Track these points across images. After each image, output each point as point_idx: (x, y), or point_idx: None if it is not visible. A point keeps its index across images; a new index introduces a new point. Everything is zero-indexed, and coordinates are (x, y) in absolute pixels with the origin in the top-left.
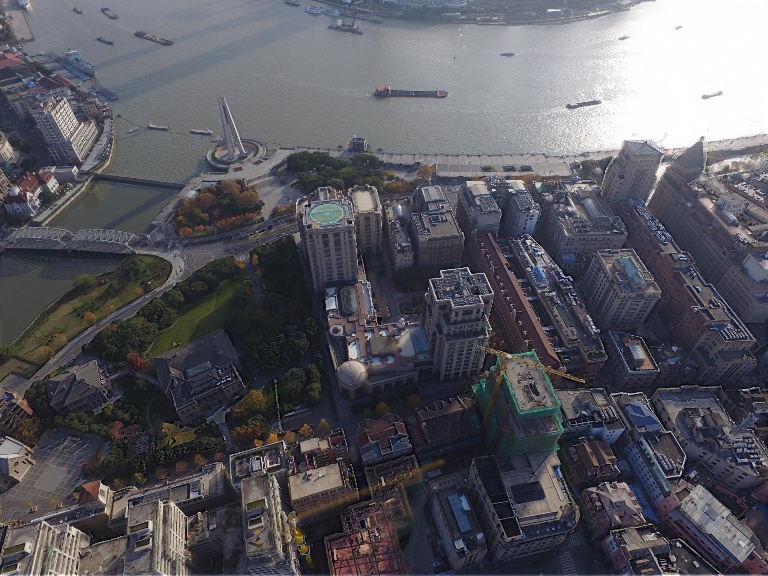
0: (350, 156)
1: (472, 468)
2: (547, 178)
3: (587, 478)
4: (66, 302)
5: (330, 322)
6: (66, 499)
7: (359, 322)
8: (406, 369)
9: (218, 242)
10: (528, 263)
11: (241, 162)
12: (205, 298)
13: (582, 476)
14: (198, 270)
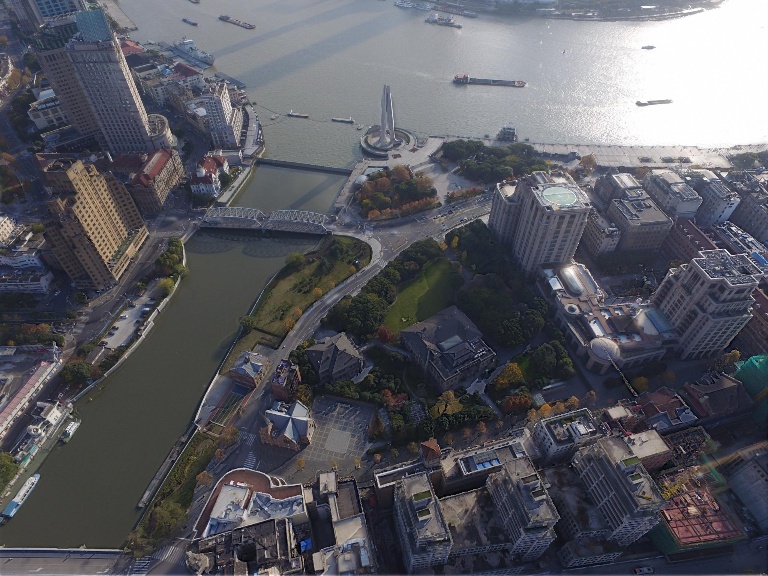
0: (506, 145)
1: None
2: (708, 169)
3: None
4: (282, 278)
5: (562, 301)
6: (361, 460)
7: (592, 302)
8: (654, 347)
9: (405, 225)
10: (744, 249)
11: (397, 149)
12: (415, 277)
13: None
14: (407, 250)
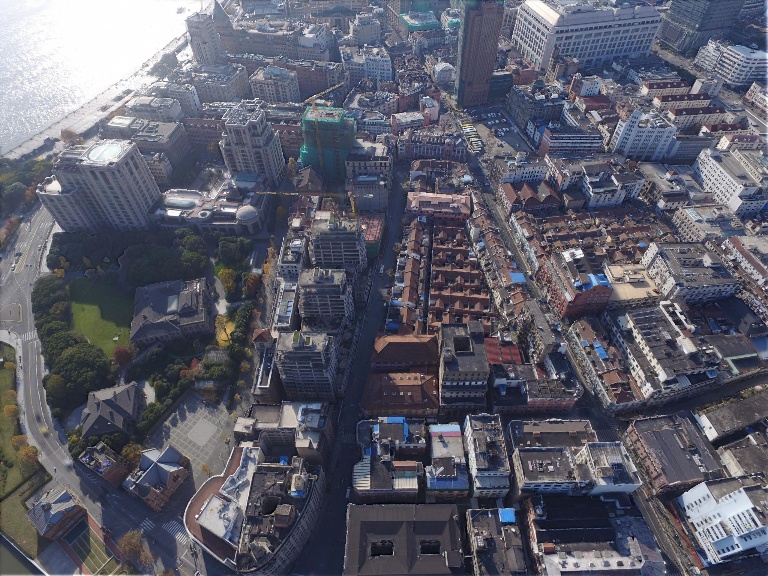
0: None
1: (348, 167)
2: None
3: None
4: None
5: (193, 216)
6: None
7: (206, 201)
8: None
9: None
10: None
11: None
12: (73, 313)
13: None
14: (36, 303)
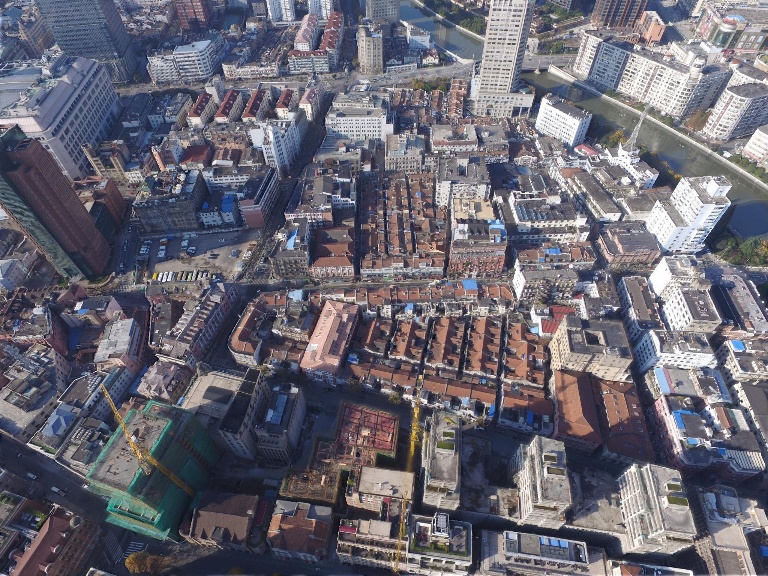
0: None
1: None
2: None
3: None
4: None
5: None
6: None
7: None
8: None
9: None
10: None
11: None
12: None
13: None
14: None
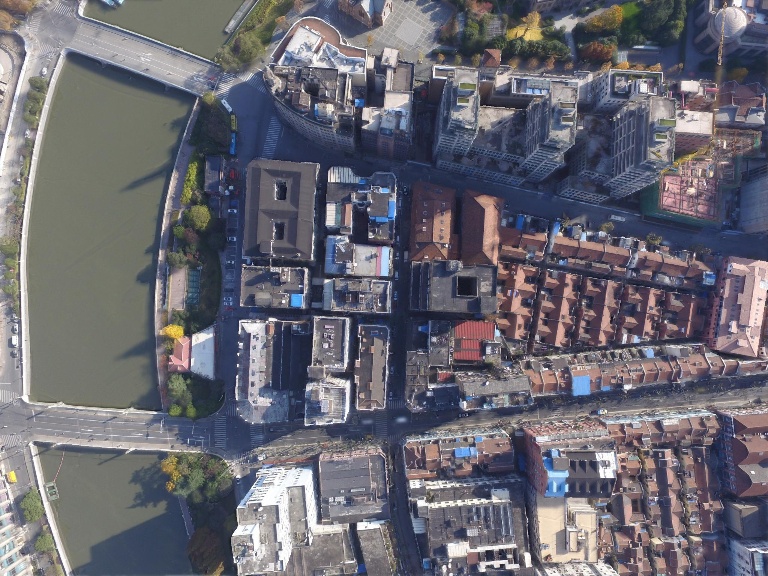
0: None
1: None
2: None
3: None
4: None
5: None
6: (425, 57)
7: None
8: None
9: None
10: None
11: None
12: None
13: None
14: None
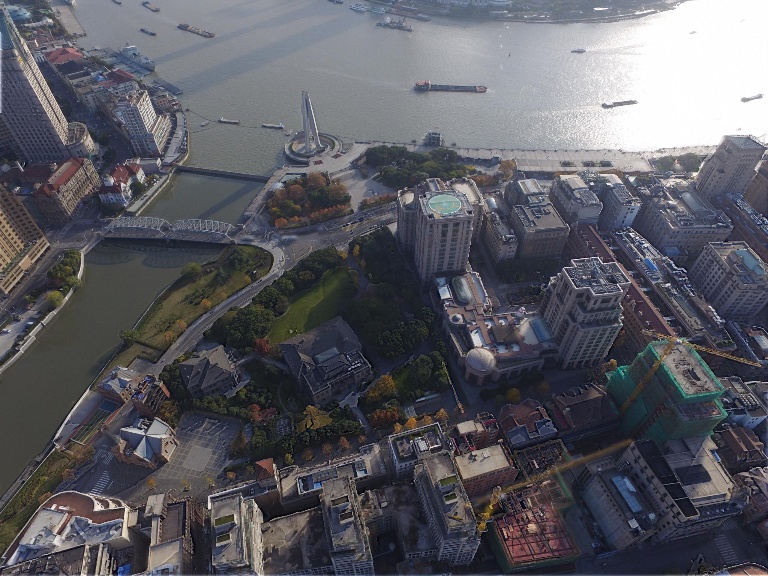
0: (429, 150)
1: (631, 451)
2: (628, 173)
3: (736, 463)
4: (176, 290)
5: (448, 311)
6: (217, 478)
7: (477, 311)
8: (532, 357)
9: (313, 233)
10: (637, 255)
11: (320, 155)
12: (311, 287)
13: (731, 461)
14: (304, 260)
